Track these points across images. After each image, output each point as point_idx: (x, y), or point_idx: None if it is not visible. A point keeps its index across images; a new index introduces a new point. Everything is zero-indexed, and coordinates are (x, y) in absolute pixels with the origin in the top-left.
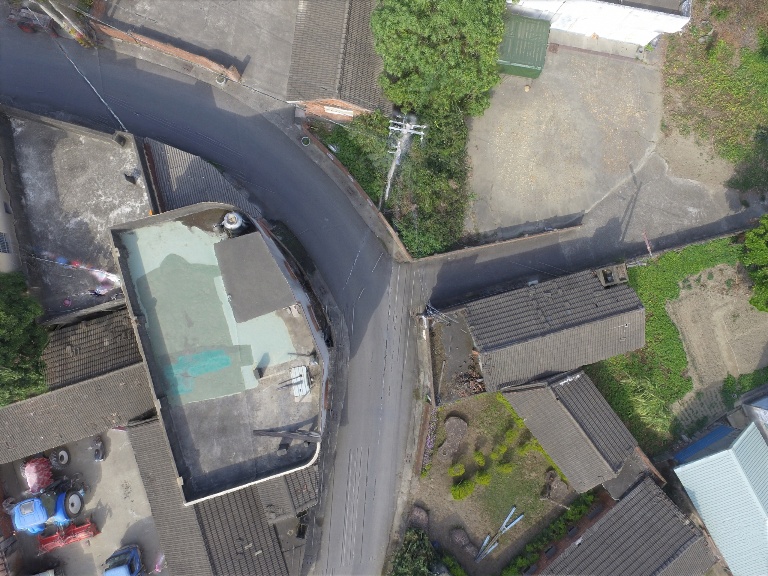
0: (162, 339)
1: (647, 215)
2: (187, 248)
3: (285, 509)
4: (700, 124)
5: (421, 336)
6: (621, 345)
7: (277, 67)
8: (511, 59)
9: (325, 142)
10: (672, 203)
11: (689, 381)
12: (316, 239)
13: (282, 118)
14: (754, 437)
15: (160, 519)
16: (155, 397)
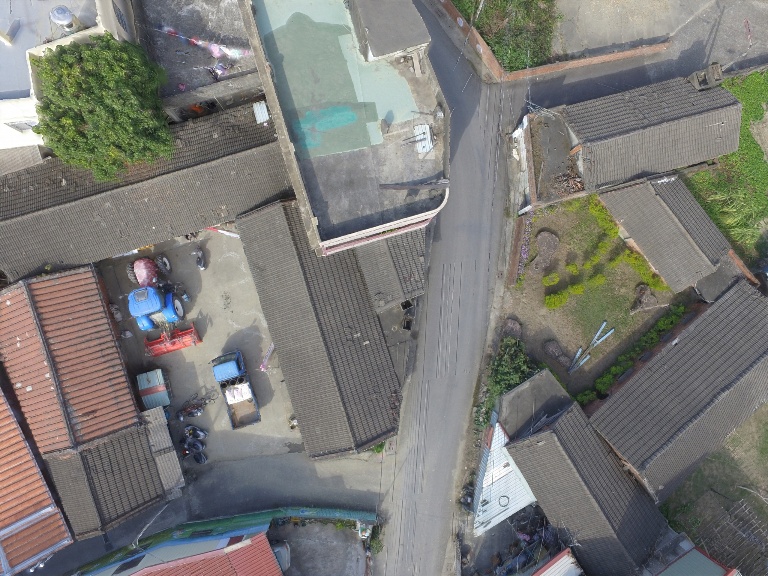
0: (289, 94)
1: (730, 38)
2: (312, 7)
3: (394, 295)
4: None
5: (511, 155)
6: (716, 146)
7: None
8: None
9: None
10: (755, 27)
11: None
12: None
13: None
14: None
15: (270, 309)
16: (289, 140)
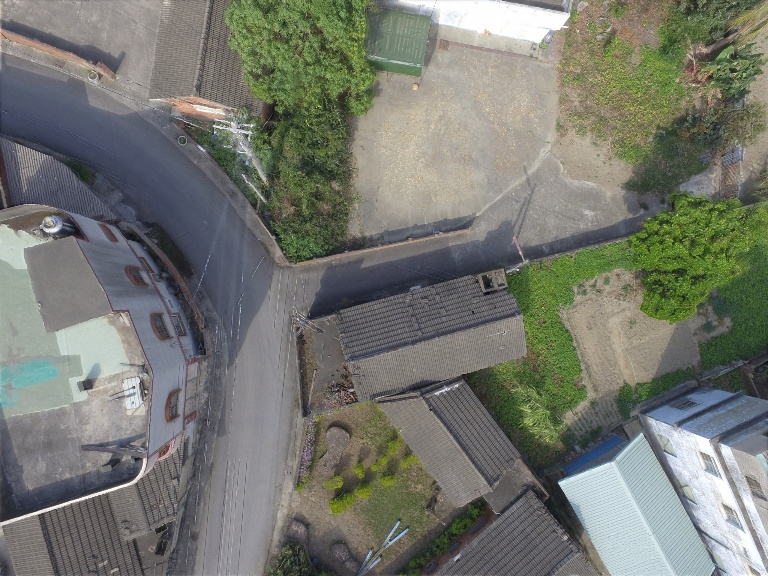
0: None
1: (541, 218)
2: (13, 253)
3: (139, 525)
4: (597, 124)
5: None
6: (501, 353)
7: (153, 63)
8: (389, 56)
9: (201, 142)
10: (567, 206)
11: (583, 390)
12: (194, 242)
13: (159, 116)
14: (641, 449)
15: (10, 535)
16: None
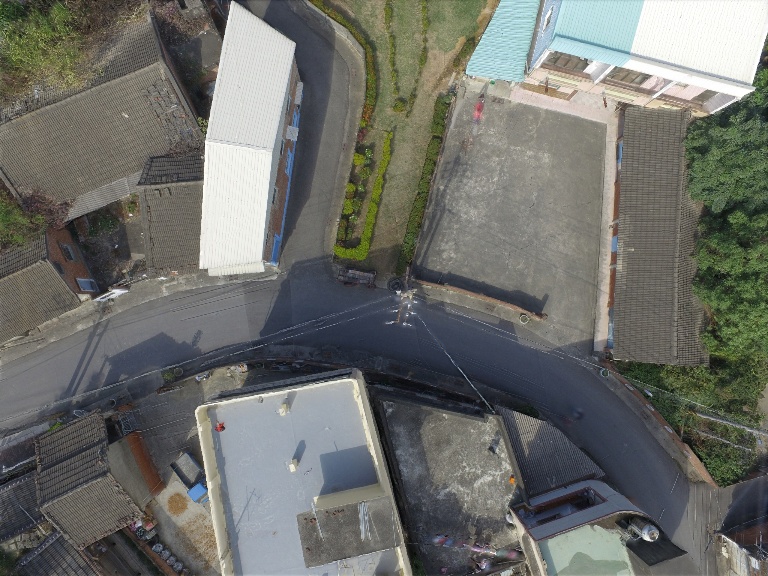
0: None
1: None
2: (591, 546)
3: None
4: None
5: (720, 553)
6: None
7: (573, 303)
8: None
9: (627, 376)
10: None
11: None
12: (617, 464)
13: (579, 350)
14: None
15: None
16: None
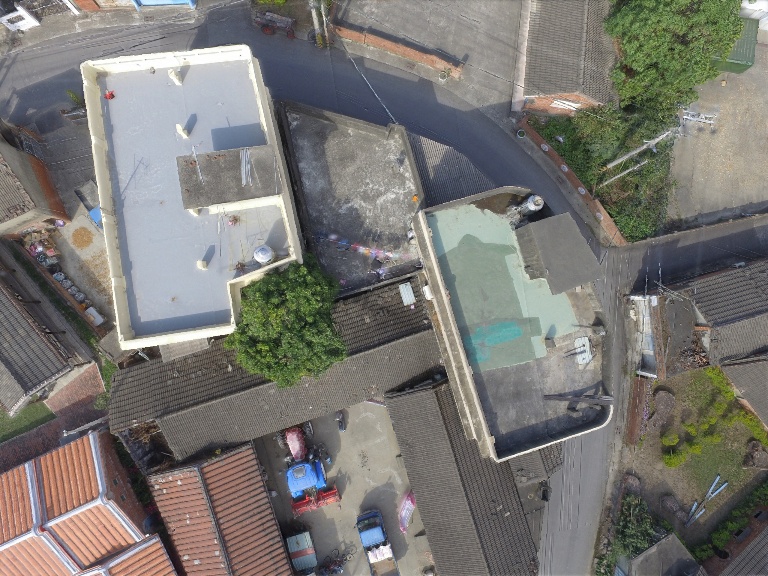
0: (461, 312)
1: None
2: (480, 229)
3: (537, 473)
4: None
5: (628, 315)
6: None
7: (493, 65)
8: None
9: (542, 134)
10: None
11: None
12: None
13: (497, 112)
14: None
15: (418, 483)
16: (467, 364)
